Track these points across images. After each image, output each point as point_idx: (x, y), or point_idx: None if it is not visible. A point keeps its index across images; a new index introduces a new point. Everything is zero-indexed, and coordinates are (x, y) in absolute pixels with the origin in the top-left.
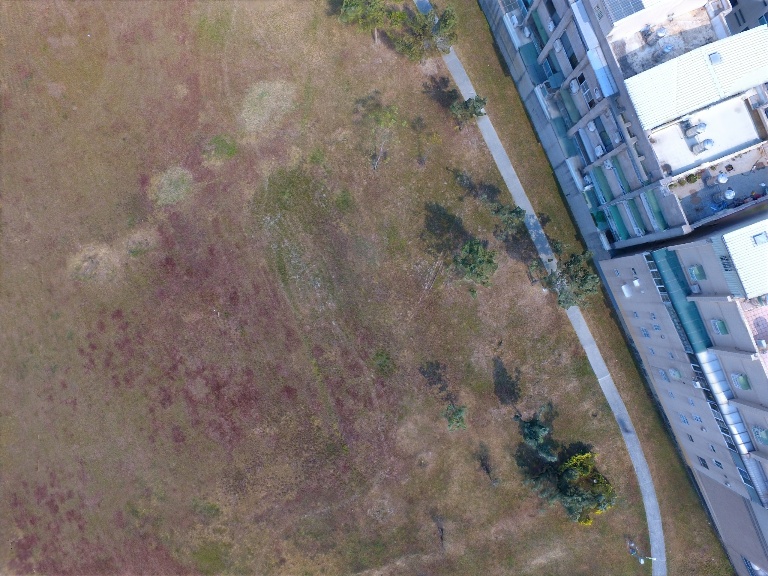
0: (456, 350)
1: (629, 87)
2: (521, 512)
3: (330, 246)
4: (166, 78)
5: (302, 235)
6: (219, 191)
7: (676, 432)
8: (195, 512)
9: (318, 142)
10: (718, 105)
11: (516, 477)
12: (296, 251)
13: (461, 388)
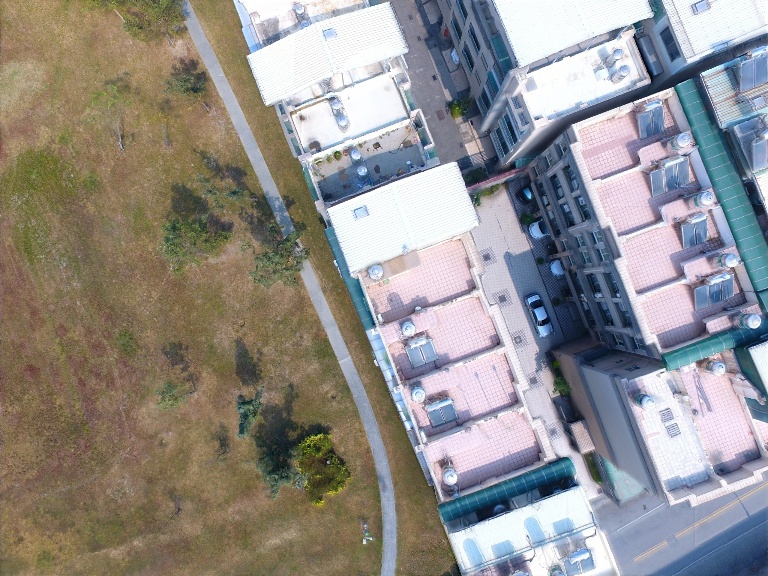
0: (199, 331)
1: (252, 62)
2: (258, 493)
3: (76, 226)
4: None
5: (49, 215)
6: None
7: None
8: None
9: (67, 122)
10: (363, 83)
11: (254, 458)
12: (43, 231)
13: (203, 369)
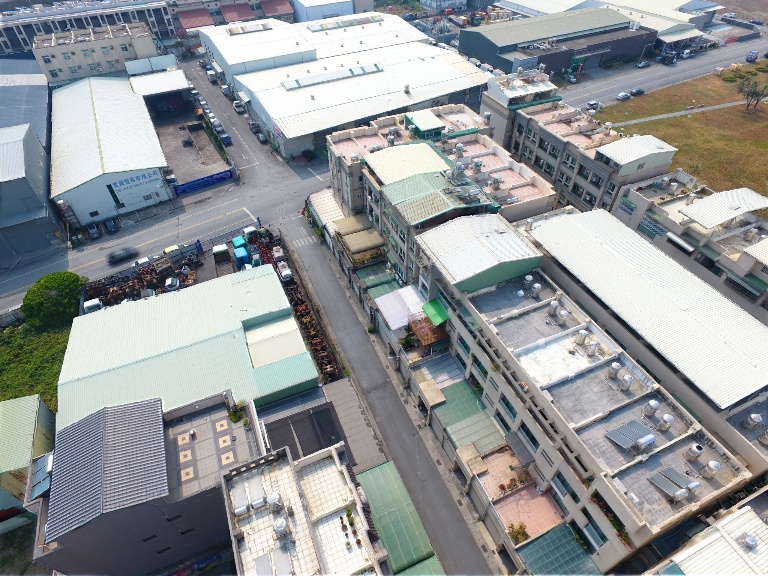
0: None
1: None
2: None
3: None
4: None
5: None
6: None
7: None
8: None
9: None
10: None
11: None
12: None
13: None
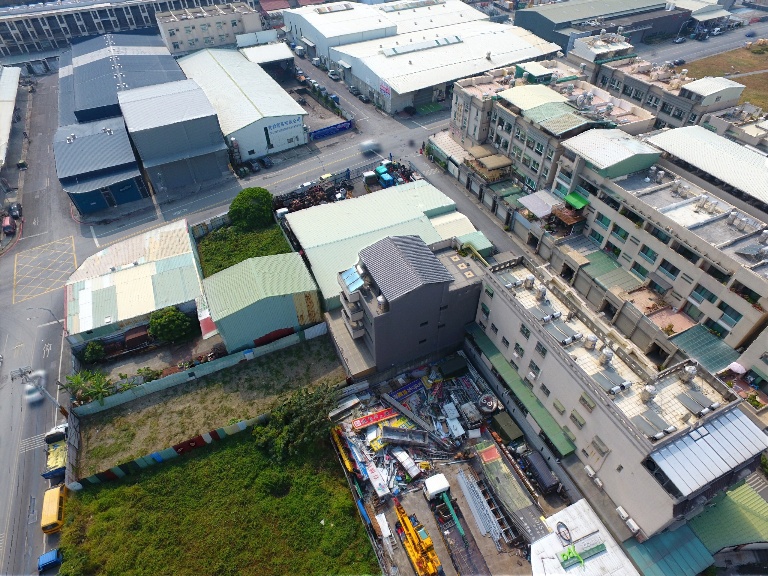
0: None
1: None
2: None
3: None
4: None
5: None
6: None
7: None
8: None
9: None
10: (764, 134)
11: None
12: None
13: None
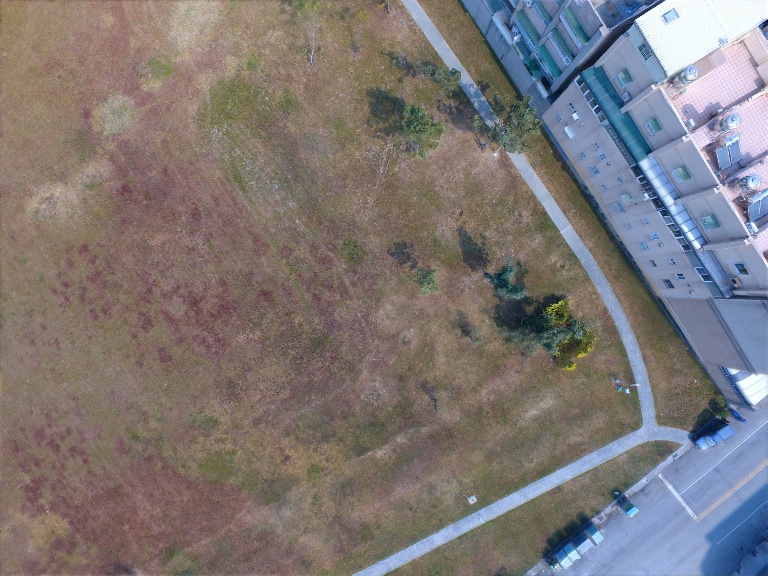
0: (420, 227)
1: None
2: (508, 370)
3: (281, 147)
4: (90, 9)
5: (252, 141)
6: (163, 112)
7: (641, 266)
8: (194, 427)
9: (252, 48)
10: None
11: (497, 338)
12: (248, 158)
13: (431, 263)
